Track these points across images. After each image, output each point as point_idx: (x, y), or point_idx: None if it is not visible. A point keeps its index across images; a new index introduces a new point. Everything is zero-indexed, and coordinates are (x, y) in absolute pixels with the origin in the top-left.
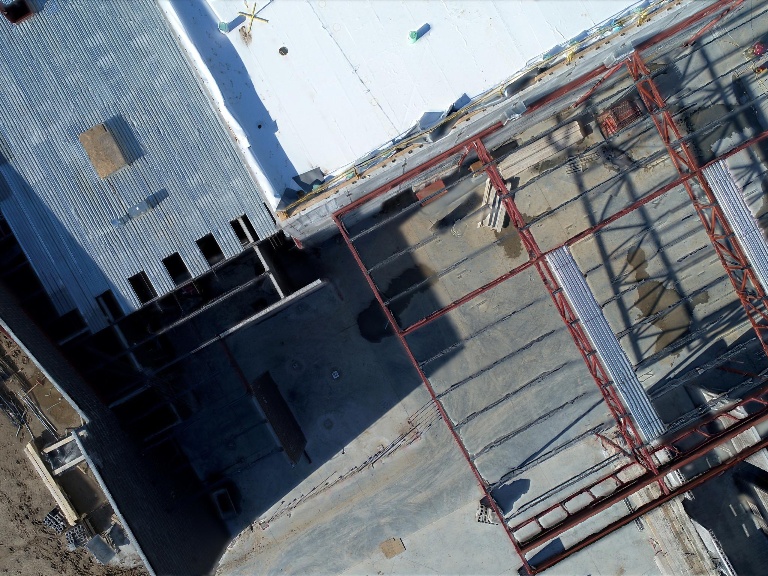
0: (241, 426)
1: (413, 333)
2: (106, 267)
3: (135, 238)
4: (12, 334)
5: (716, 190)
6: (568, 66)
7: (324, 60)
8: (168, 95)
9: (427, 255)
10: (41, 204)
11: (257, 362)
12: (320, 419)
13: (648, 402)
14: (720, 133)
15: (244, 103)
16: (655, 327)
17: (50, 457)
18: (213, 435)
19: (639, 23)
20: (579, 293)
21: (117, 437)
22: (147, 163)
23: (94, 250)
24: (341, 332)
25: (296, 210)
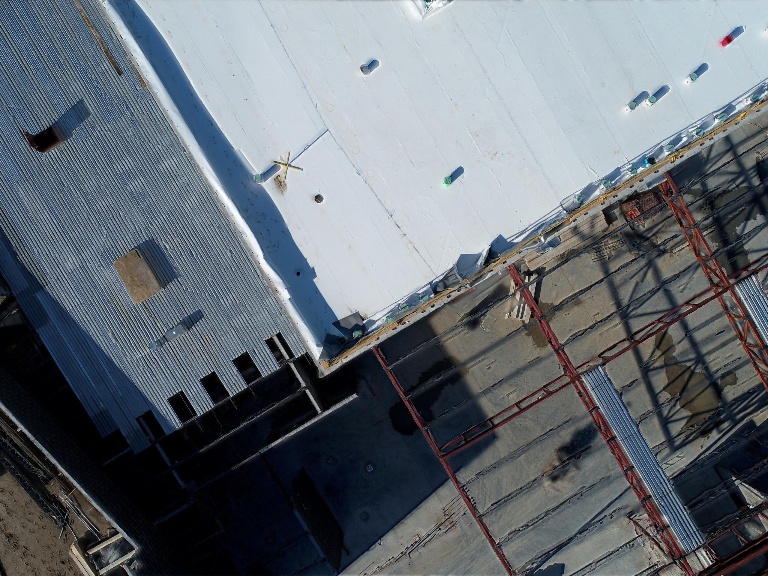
0: (279, 521)
1: (445, 425)
2: (145, 388)
3: (172, 359)
4: (59, 466)
5: (749, 305)
6: (603, 205)
7: (359, 206)
8: (199, 217)
9: (456, 347)
10: (79, 329)
11: (292, 458)
12: (356, 512)
13: (686, 515)
14: (745, 215)
15: (282, 251)
16: (684, 410)
17: (94, 558)
18: (252, 531)
19: (672, 160)
20: (615, 411)
21: (164, 556)
22: (181, 285)
23: (133, 372)
24: (374, 426)
25: (338, 358)
